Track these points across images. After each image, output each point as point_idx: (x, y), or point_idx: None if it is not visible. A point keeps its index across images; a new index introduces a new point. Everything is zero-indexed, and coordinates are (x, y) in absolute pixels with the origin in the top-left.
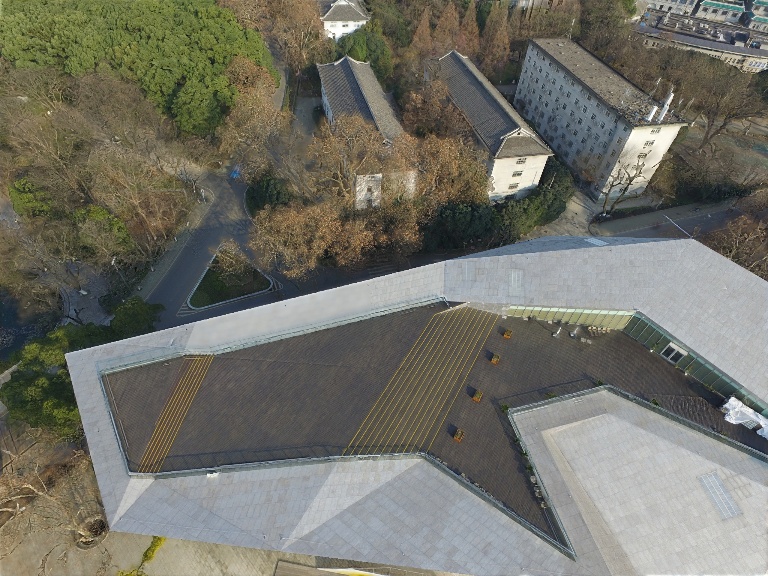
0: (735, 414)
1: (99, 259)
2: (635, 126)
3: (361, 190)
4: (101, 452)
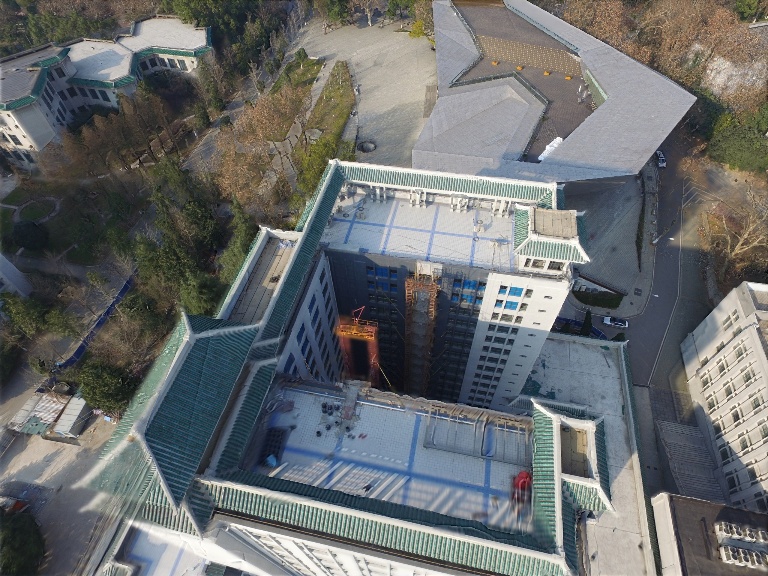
0: None
1: (559, 7)
2: None
3: None
4: None
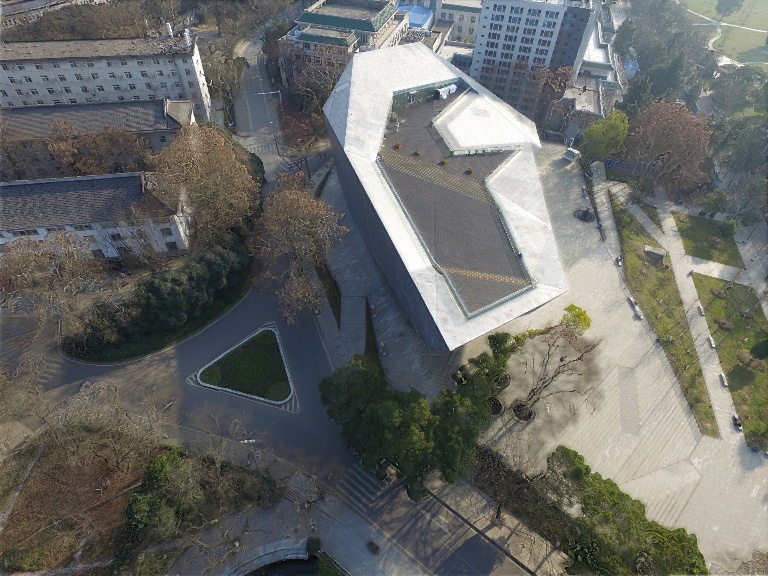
0: (443, 94)
1: None
2: (192, 53)
3: (179, 227)
4: (525, 306)
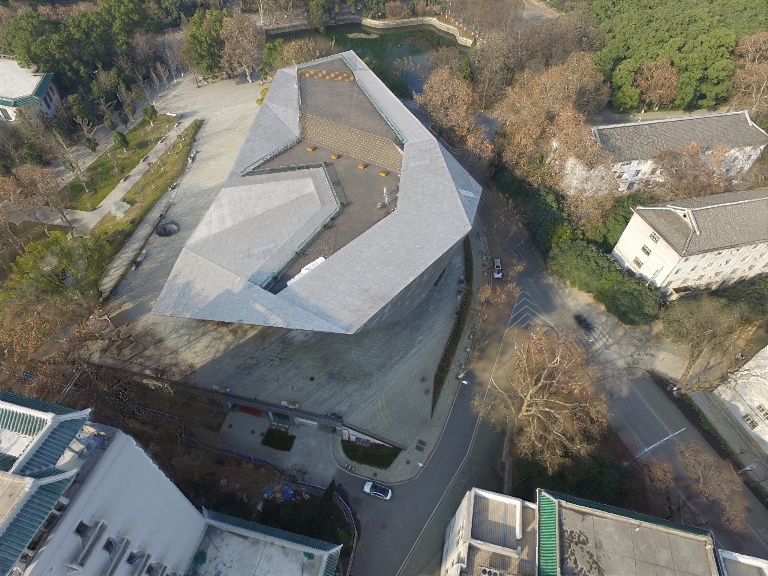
0: None
1: None
2: None
3: None
4: None
